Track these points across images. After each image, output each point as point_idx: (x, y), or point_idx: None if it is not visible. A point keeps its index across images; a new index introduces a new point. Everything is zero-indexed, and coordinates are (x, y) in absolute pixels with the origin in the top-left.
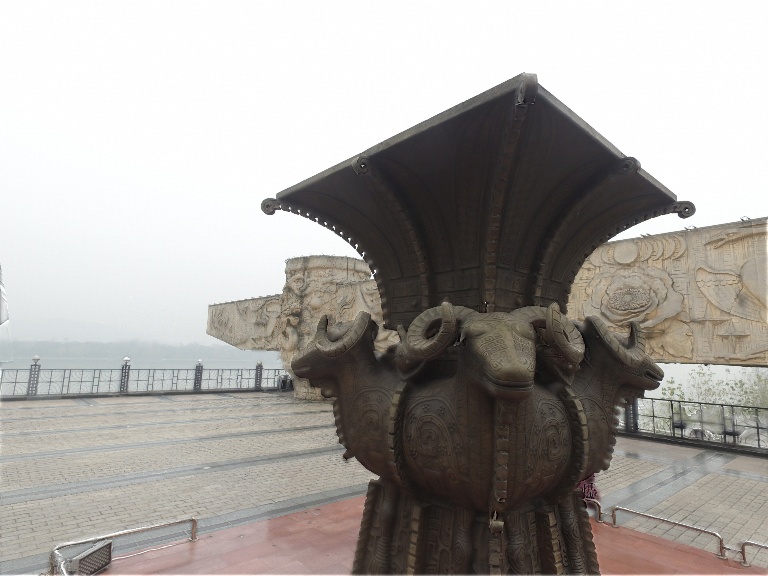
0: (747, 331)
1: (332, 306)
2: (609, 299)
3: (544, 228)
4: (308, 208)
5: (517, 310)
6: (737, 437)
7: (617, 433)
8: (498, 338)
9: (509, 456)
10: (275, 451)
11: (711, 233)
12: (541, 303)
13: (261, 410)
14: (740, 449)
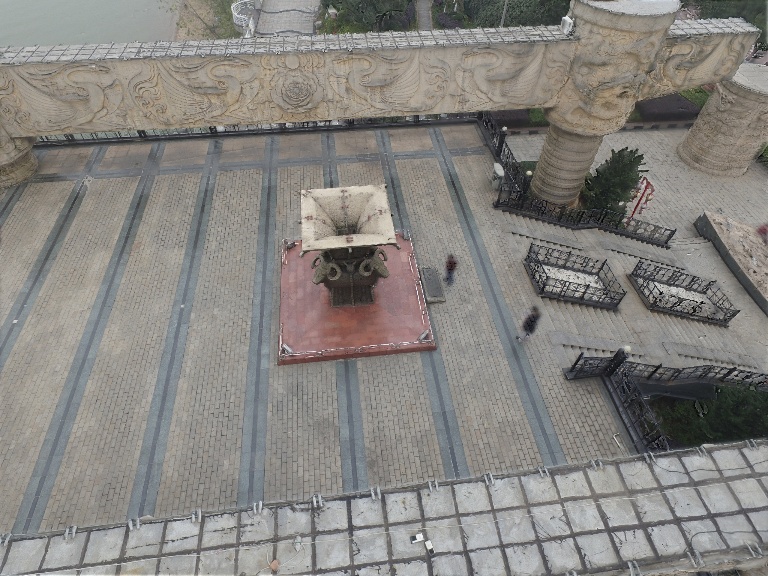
0: (349, 105)
1: None
2: (286, 91)
3: None
4: None
5: (376, 255)
6: (331, 122)
7: (277, 132)
8: (382, 269)
9: None
10: (175, 272)
11: (335, 54)
12: None
13: (25, 233)
14: (332, 128)
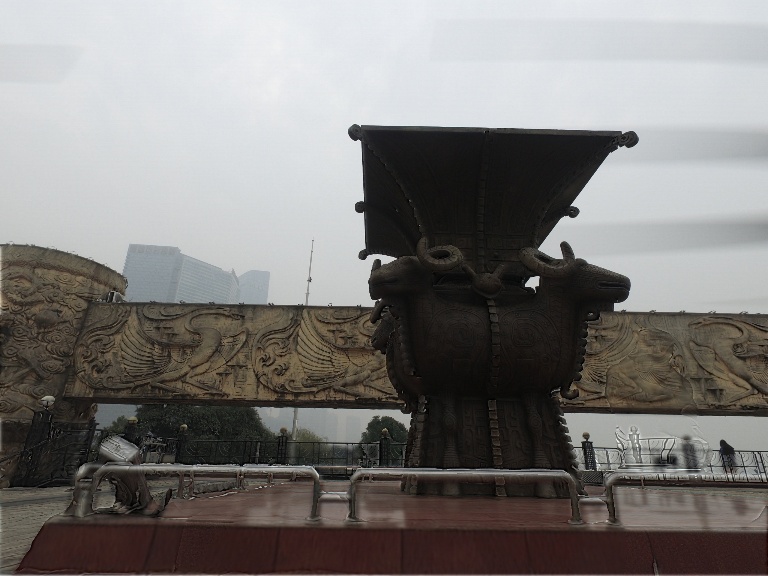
0: None
1: None
2: None
3: None
4: None
5: None
6: None
7: None
8: None
9: None
10: None
11: None
12: None
13: None
14: None
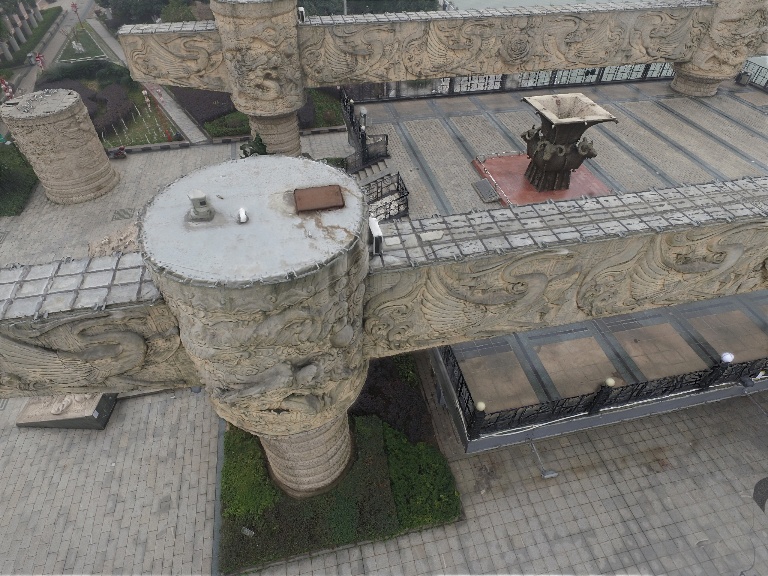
0: None
1: None
2: None
3: None
4: None
5: None
6: None
7: None
8: None
9: None
10: None
11: None
12: None
13: None
14: None
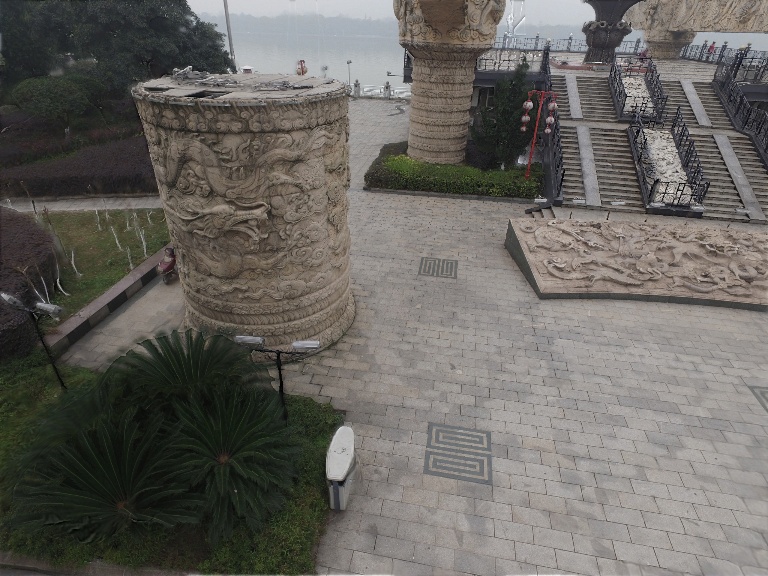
0: (764, 19)
1: (674, 2)
2: None
3: (613, 8)
4: (588, 2)
5: None
6: None
7: None
8: None
9: (594, 40)
10: None
11: None
12: (614, 19)
13: None
14: None
